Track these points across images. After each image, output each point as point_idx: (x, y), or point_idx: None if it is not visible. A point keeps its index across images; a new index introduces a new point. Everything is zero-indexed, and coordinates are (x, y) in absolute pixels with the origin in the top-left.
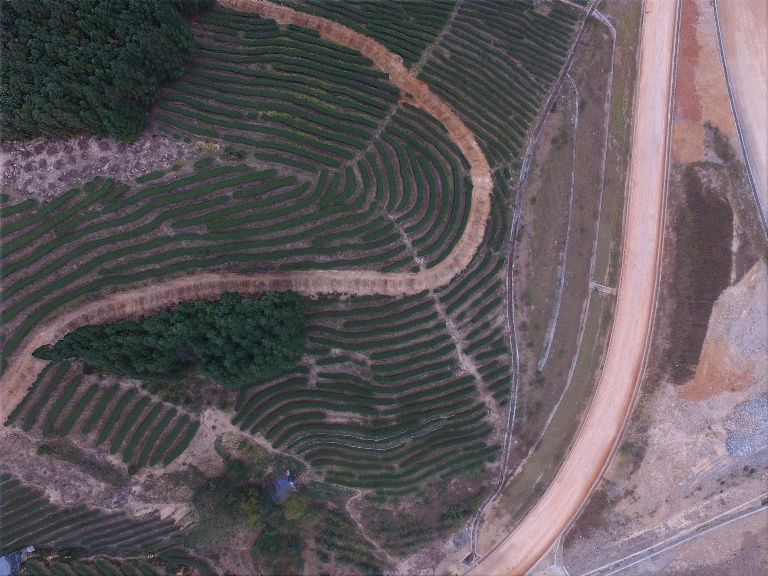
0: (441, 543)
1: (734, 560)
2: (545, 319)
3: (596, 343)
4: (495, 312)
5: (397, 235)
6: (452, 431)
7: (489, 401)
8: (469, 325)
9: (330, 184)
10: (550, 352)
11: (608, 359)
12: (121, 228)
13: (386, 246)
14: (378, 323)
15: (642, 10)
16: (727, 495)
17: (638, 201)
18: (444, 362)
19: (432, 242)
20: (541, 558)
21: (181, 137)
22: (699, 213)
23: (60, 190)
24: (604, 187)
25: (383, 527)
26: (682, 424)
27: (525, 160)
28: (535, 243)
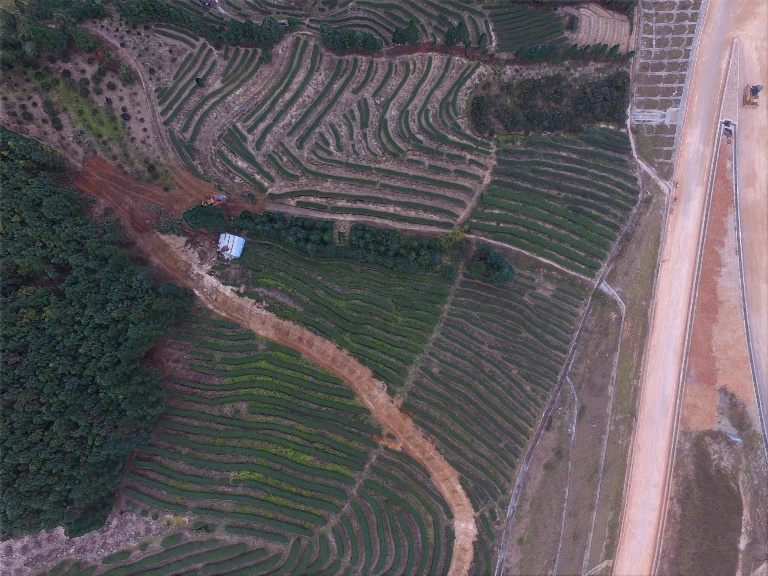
0: None
1: None
2: None
3: None
4: None
5: None
6: None
7: None
8: None
9: (302, 554)
10: None
11: None
12: None
13: None
14: None
15: (658, 259)
16: None
17: (642, 467)
18: None
19: None
20: None
21: (149, 512)
22: (707, 493)
23: (26, 574)
24: (603, 477)
25: None
26: None
27: (514, 492)
28: None
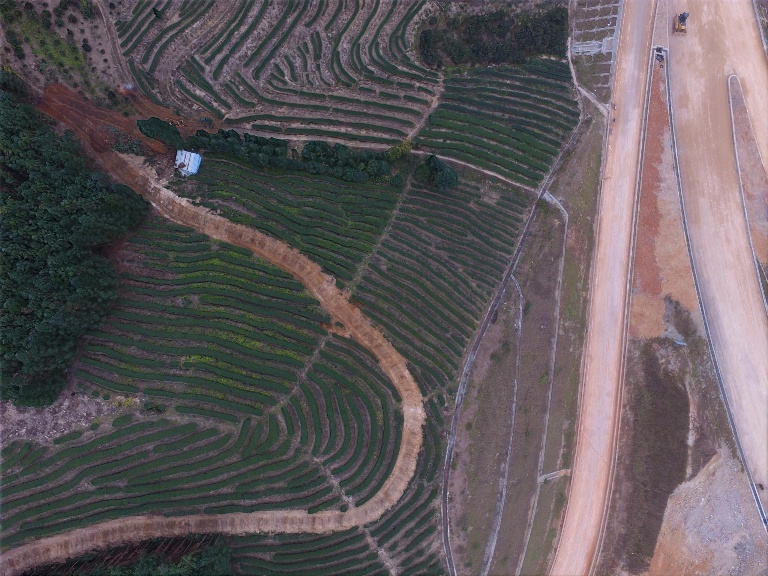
0: None
1: None
2: (485, 534)
3: (548, 528)
4: (430, 538)
5: (323, 479)
6: None
7: None
8: (402, 553)
9: (252, 434)
10: (491, 566)
11: (562, 541)
12: (41, 487)
13: (312, 488)
14: (308, 556)
15: (601, 177)
16: None
17: (595, 377)
18: None
19: (361, 480)
20: None
21: (100, 393)
22: (656, 396)
23: None
24: (554, 379)
25: None
26: None
27: (462, 380)
28: (471, 467)
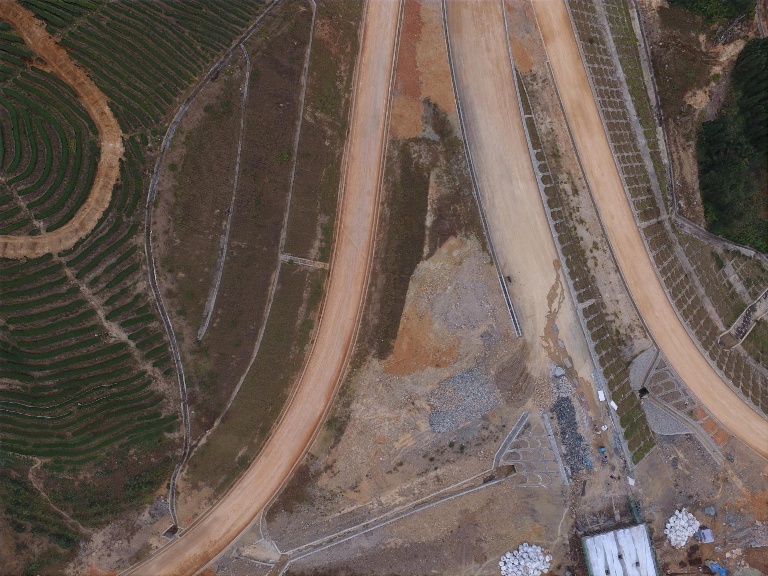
0: (136, 514)
1: (450, 537)
2: (204, 288)
3: (303, 317)
4: (135, 278)
5: (6, 197)
6: (122, 400)
7: (152, 370)
8: (106, 291)
9: None
10: (211, 321)
11: (320, 334)
12: None
13: None
14: (4, 286)
15: None
16: (443, 472)
17: (356, 176)
18: (86, 328)
19: (51, 205)
20: (242, 531)
21: None
22: (407, 188)
23: None
24: (297, 159)
25: (66, 496)
26: (385, 399)
27: (172, 127)
28: (178, 210)
